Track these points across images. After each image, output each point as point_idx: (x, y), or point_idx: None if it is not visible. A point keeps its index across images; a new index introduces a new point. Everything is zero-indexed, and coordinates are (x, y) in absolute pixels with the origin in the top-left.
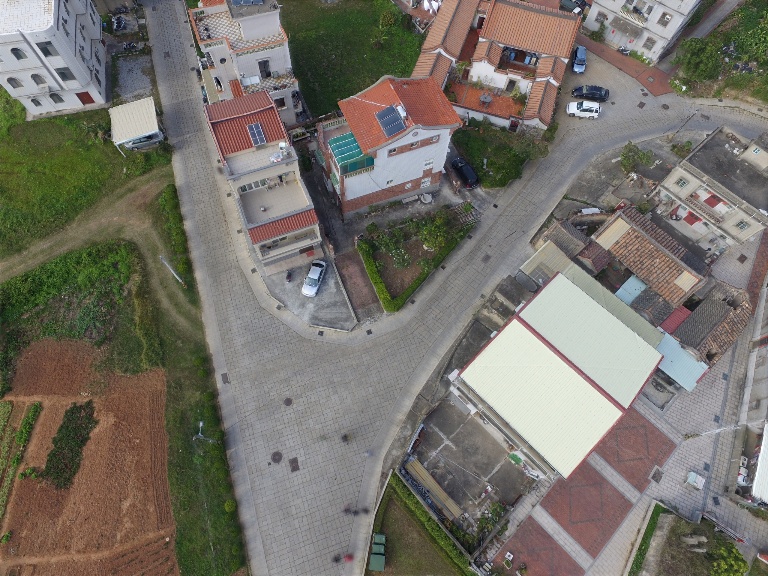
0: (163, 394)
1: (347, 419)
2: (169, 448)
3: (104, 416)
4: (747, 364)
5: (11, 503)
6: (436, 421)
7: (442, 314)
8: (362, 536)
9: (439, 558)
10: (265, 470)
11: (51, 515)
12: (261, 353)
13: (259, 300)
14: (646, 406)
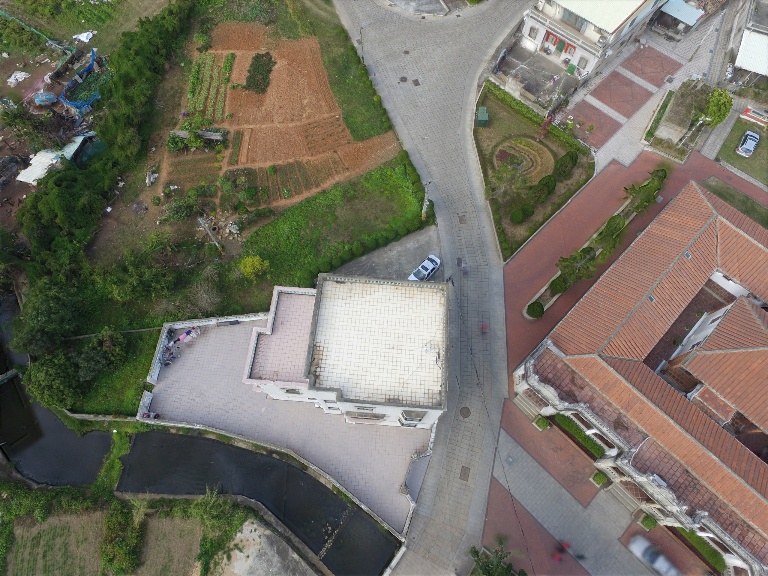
0: (318, 49)
1: (449, 60)
2: (328, 75)
3: (279, 60)
4: (733, 23)
5: (227, 101)
6: (513, 56)
7: (510, 5)
8: (469, 114)
9: (522, 124)
10: (396, 86)
11: (256, 106)
12: (382, 29)
13: (375, 2)
14: (661, 46)
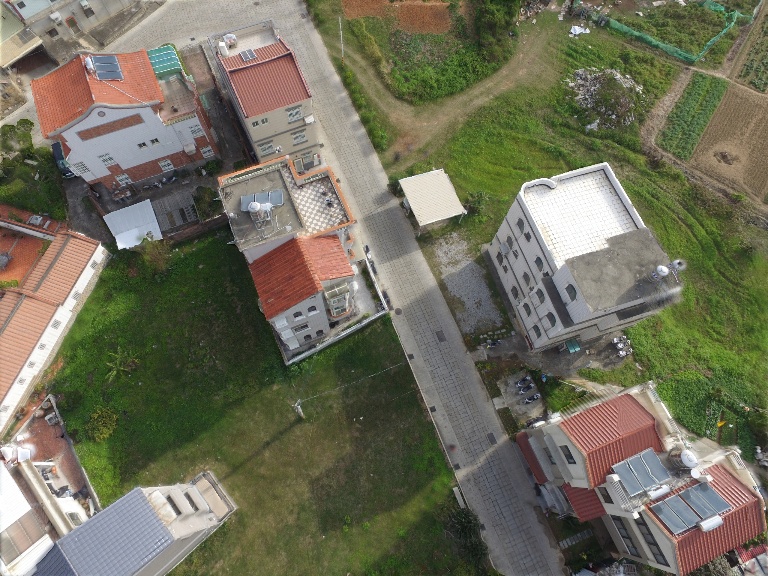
0: (344, 7)
1: None
2: None
3: None
4: None
5: None
6: None
7: None
8: None
9: None
10: None
11: None
12: None
13: None
14: None
